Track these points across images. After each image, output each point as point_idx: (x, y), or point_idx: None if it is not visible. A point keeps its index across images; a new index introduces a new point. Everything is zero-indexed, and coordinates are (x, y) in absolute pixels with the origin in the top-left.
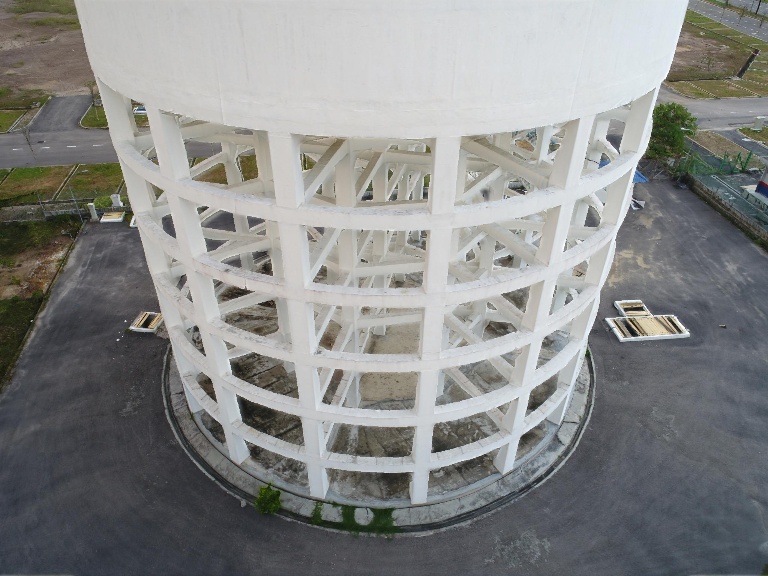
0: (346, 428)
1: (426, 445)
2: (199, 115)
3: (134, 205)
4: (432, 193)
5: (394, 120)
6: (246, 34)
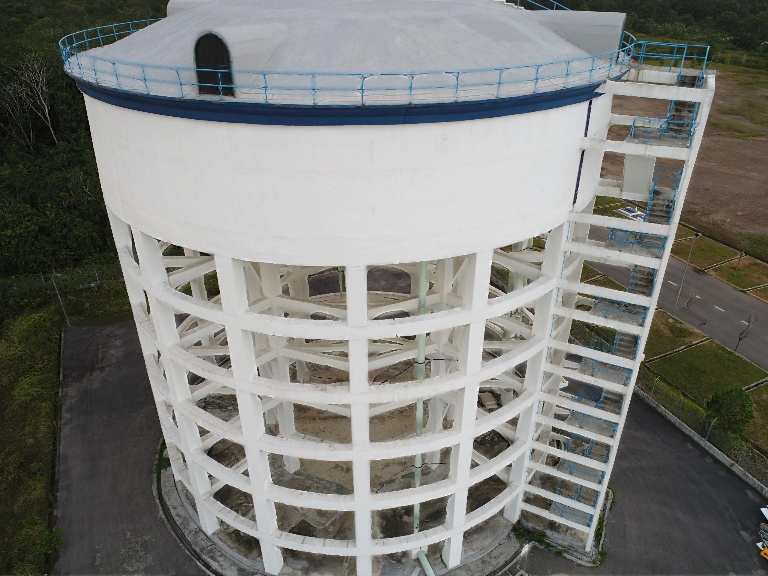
0: None
1: None
2: None
3: None
4: None
5: None
6: None
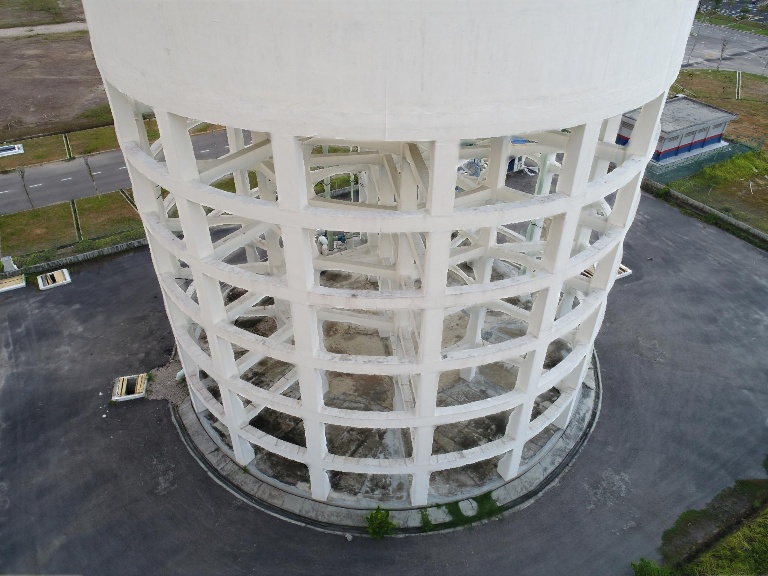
0: (407, 432)
1: (527, 420)
2: (354, 135)
3: (198, 251)
4: (573, 177)
5: (557, 112)
6: (428, 44)
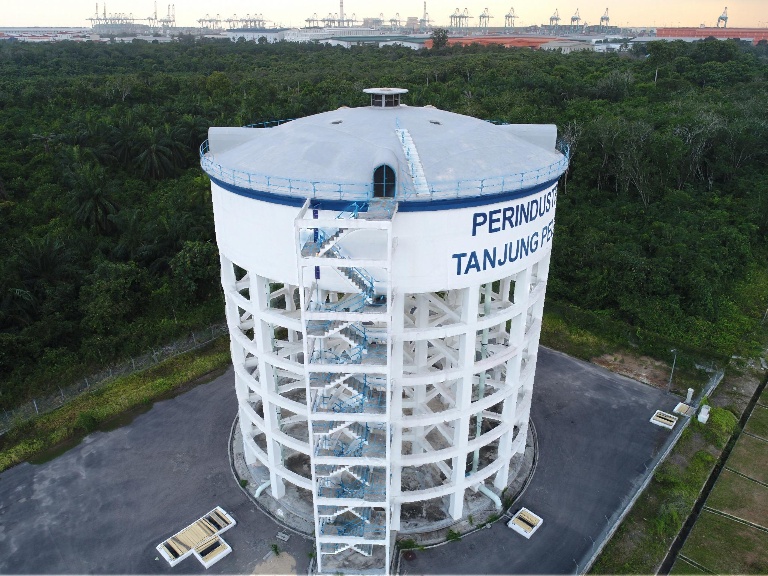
0: None
1: None
2: None
3: None
4: None
5: None
6: None
